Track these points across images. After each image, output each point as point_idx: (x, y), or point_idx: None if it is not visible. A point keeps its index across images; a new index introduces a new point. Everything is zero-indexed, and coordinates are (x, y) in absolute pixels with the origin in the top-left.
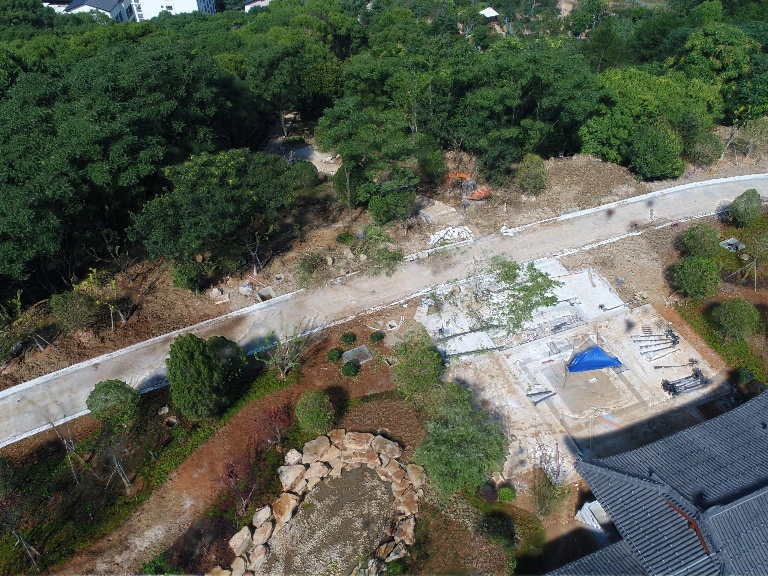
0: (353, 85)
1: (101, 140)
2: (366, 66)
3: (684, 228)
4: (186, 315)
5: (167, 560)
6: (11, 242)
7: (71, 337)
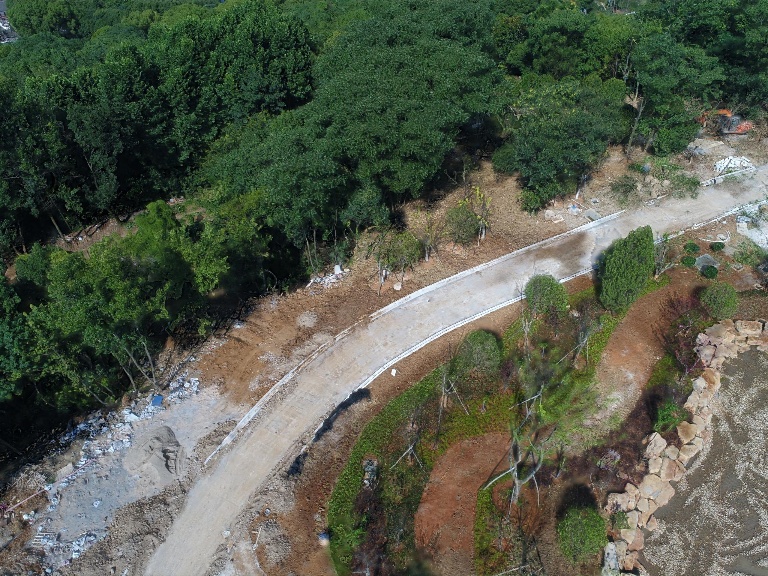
0: (556, 38)
1: (475, 72)
2: (569, 19)
3: None
4: (533, 232)
5: (640, 416)
6: (411, 163)
7: (445, 250)
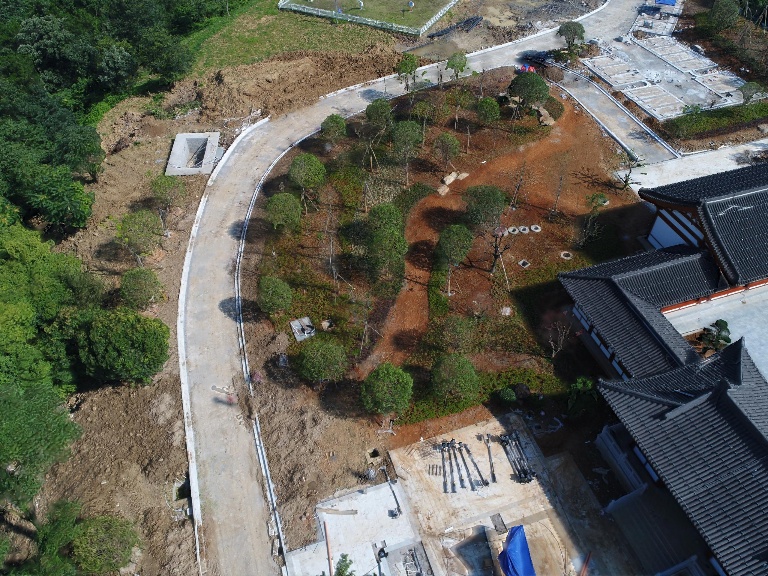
0: None
1: None
2: None
3: (260, 365)
4: None
5: None
6: None
7: None
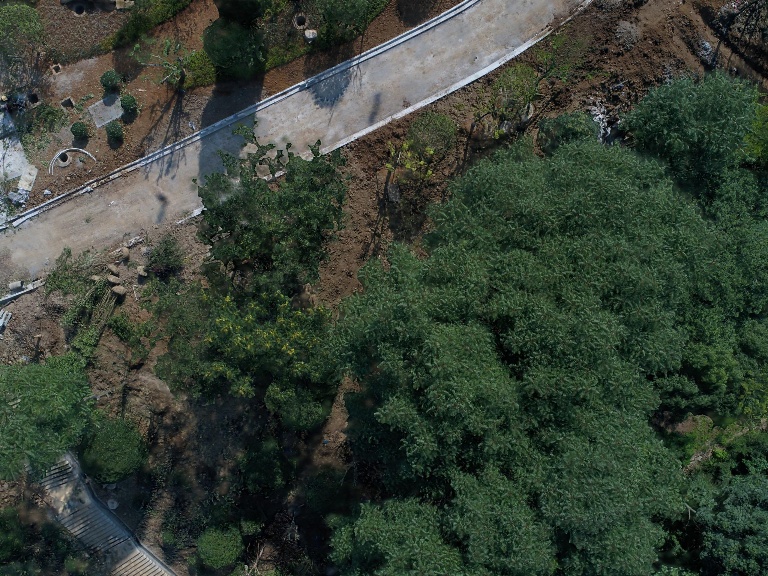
0: None
1: None
2: None
3: None
4: None
5: None
6: None
7: None
